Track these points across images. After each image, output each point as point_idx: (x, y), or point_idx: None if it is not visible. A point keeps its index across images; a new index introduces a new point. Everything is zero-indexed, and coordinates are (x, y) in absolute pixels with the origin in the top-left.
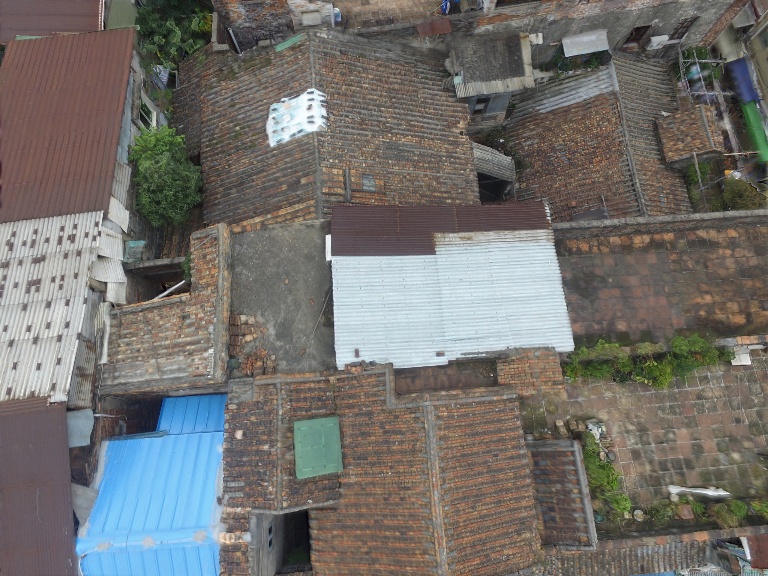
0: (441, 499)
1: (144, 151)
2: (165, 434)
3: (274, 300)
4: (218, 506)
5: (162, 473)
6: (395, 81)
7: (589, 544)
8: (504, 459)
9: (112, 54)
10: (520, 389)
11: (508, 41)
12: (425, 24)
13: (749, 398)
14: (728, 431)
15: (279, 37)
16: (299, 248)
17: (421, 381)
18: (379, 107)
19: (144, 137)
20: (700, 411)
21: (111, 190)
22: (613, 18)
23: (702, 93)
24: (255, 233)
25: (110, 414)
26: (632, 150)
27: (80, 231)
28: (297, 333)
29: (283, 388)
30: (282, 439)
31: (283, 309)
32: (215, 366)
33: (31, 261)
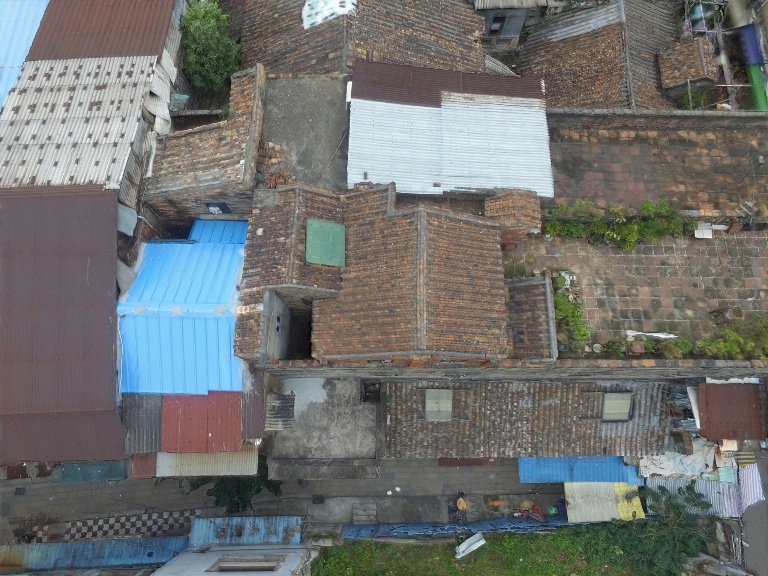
0: (426, 283)
1: None
2: (195, 243)
3: (298, 134)
4: (237, 291)
5: (191, 267)
6: None
7: (550, 357)
8: (483, 271)
9: None
10: (503, 220)
11: None
12: None
13: (708, 268)
14: (685, 293)
15: None
16: (323, 95)
17: None
18: (404, 6)
19: (195, 8)
20: (662, 274)
21: (165, 43)
22: None
23: (702, 31)
24: (287, 80)
25: (149, 223)
26: (631, 75)
27: (137, 69)
28: (316, 161)
29: (301, 194)
30: (296, 233)
31: (305, 142)
32: (245, 172)
33: (94, 88)
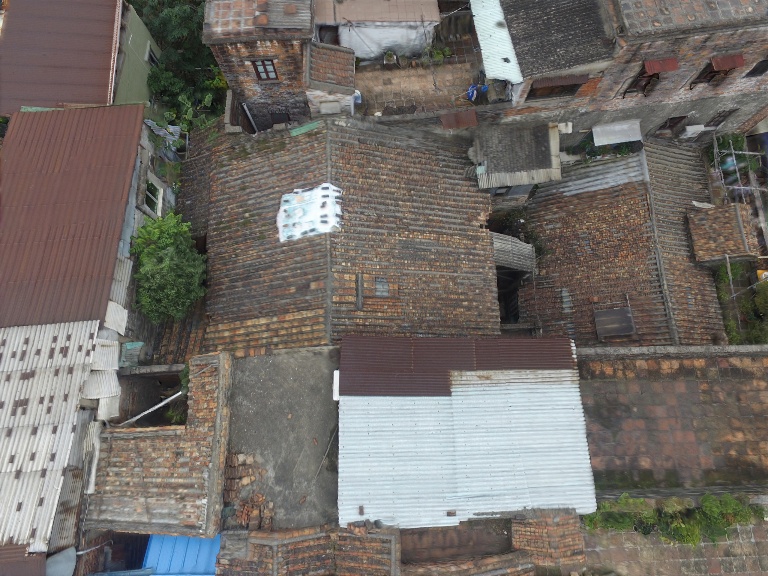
0: None
1: (147, 244)
2: (152, 572)
3: (275, 437)
4: None
5: None
6: (415, 171)
7: None
8: None
9: (119, 134)
10: (536, 558)
11: (536, 131)
12: (450, 115)
13: None
14: None
15: (295, 121)
16: (305, 378)
17: (429, 538)
18: (397, 201)
19: (148, 229)
20: (727, 570)
21: (109, 294)
22: (648, 110)
23: (737, 187)
24: (259, 358)
25: (95, 546)
26: (661, 247)
27: (73, 343)
28: (298, 477)
29: (280, 550)
30: None
31: (284, 448)
32: (208, 521)
33: (19, 377)
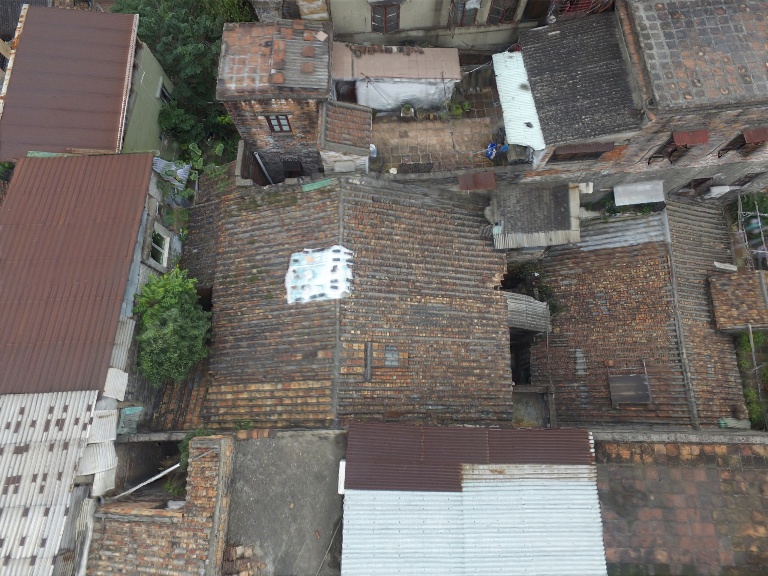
0: None
1: (151, 303)
2: None
3: (276, 528)
4: None
5: None
6: (429, 230)
7: None
8: None
9: (127, 185)
10: None
11: (555, 191)
12: (467, 176)
13: None
14: None
15: (308, 176)
16: (309, 464)
17: None
18: (410, 263)
19: (152, 288)
20: None
21: (110, 361)
22: (672, 172)
23: (761, 251)
24: (262, 441)
25: None
26: (680, 313)
27: (70, 415)
28: (298, 573)
29: None
30: None
31: (285, 541)
32: None
33: (13, 451)
